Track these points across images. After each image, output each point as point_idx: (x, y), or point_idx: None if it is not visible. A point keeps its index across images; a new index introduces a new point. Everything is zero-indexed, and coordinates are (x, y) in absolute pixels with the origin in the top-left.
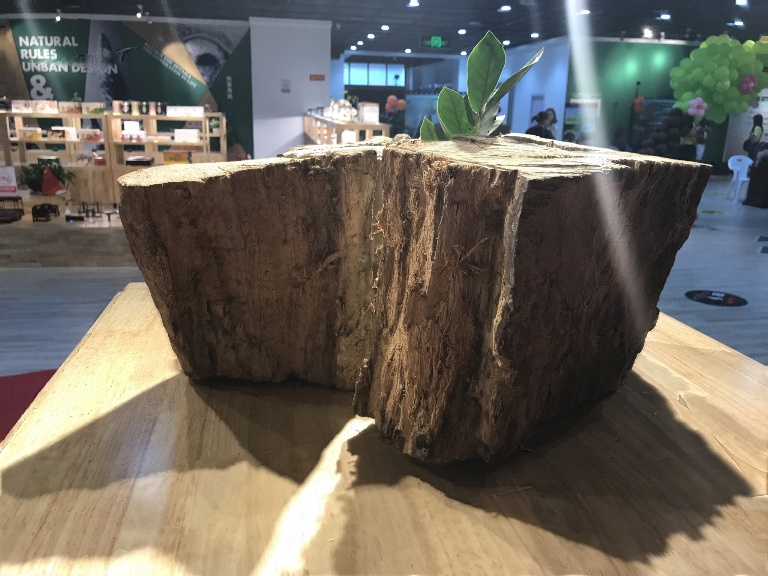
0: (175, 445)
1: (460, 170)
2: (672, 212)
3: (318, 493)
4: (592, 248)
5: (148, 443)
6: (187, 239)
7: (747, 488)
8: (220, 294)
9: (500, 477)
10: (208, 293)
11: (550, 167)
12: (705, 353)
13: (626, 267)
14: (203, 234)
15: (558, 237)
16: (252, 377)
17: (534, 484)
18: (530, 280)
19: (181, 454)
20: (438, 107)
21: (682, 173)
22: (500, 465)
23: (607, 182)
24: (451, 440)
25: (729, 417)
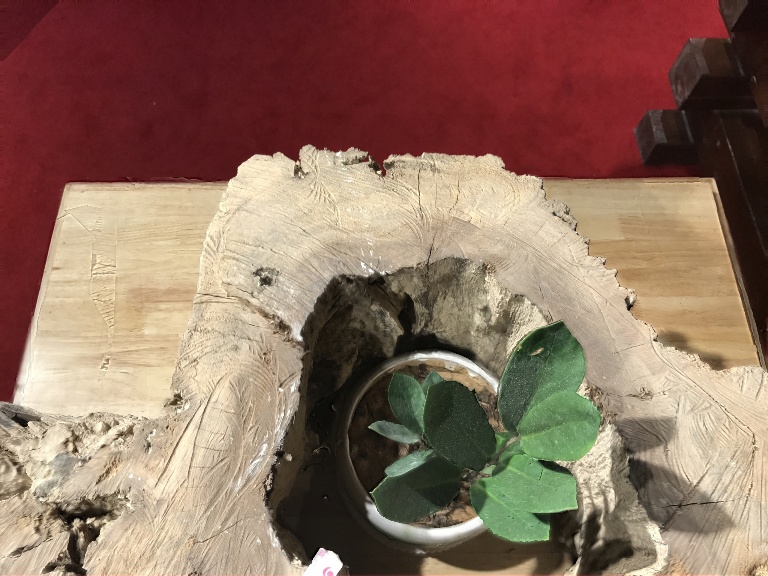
0: None
1: None
2: None
3: None
4: None
5: None
6: None
7: None
8: None
9: None
10: None
11: None
12: None
13: None
14: None
15: None
16: None
17: None
18: None
19: None
20: (534, 512)
21: None
22: None
23: None
24: None
25: None
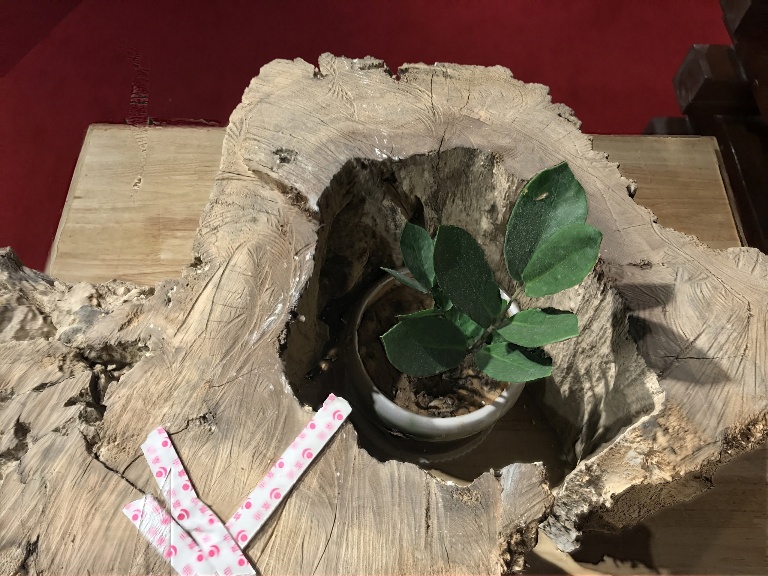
0: None
1: None
2: None
3: None
4: None
5: None
6: None
7: None
8: None
9: None
10: None
11: None
12: None
13: None
14: None
15: None
16: None
17: None
18: None
19: None
20: None
21: None
22: None
23: None
24: None
25: None
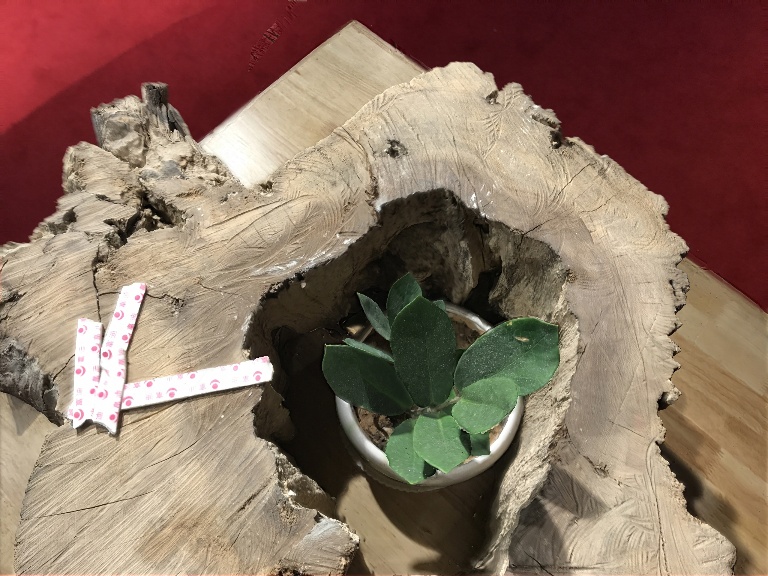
0: None
1: None
2: None
3: None
4: None
5: None
6: None
7: (697, 486)
8: None
9: None
10: None
11: None
12: None
13: None
14: None
15: None
16: None
17: None
18: None
19: None
20: None
21: None
22: None
23: None
24: None
25: None
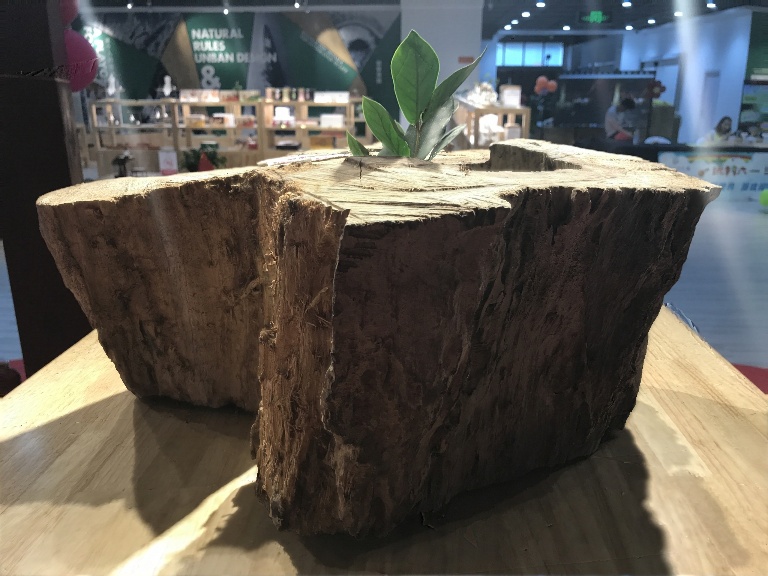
0: (71, 472)
1: (299, 206)
2: (644, 250)
3: (166, 550)
4: (452, 307)
5: (48, 466)
6: (105, 259)
7: None
8: (150, 314)
9: (374, 559)
10: (139, 313)
11: (399, 205)
12: (741, 414)
13: (582, 315)
14: (124, 253)
15: (390, 295)
16: (191, 400)
17: (408, 574)
18: (357, 345)
19: (68, 483)
20: (366, 119)
21: (654, 202)
22: (383, 543)
23: (465, 227)
24: (309, 512)
25: (718, 511)
